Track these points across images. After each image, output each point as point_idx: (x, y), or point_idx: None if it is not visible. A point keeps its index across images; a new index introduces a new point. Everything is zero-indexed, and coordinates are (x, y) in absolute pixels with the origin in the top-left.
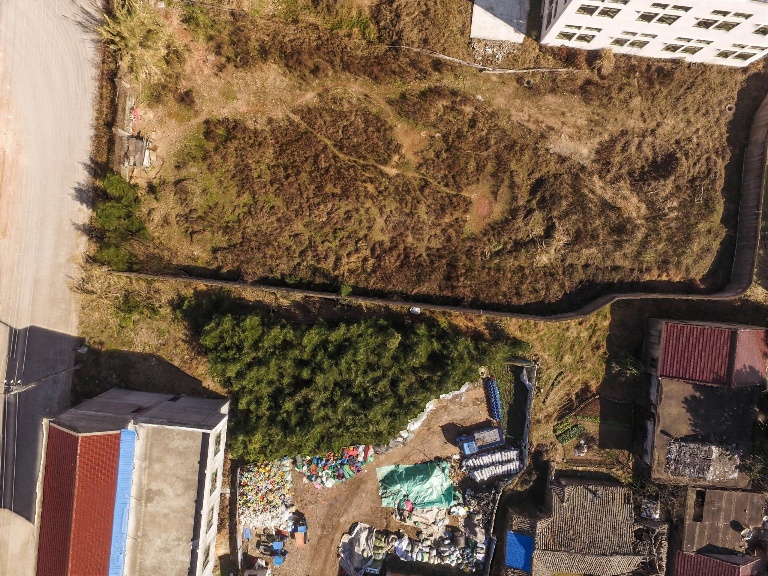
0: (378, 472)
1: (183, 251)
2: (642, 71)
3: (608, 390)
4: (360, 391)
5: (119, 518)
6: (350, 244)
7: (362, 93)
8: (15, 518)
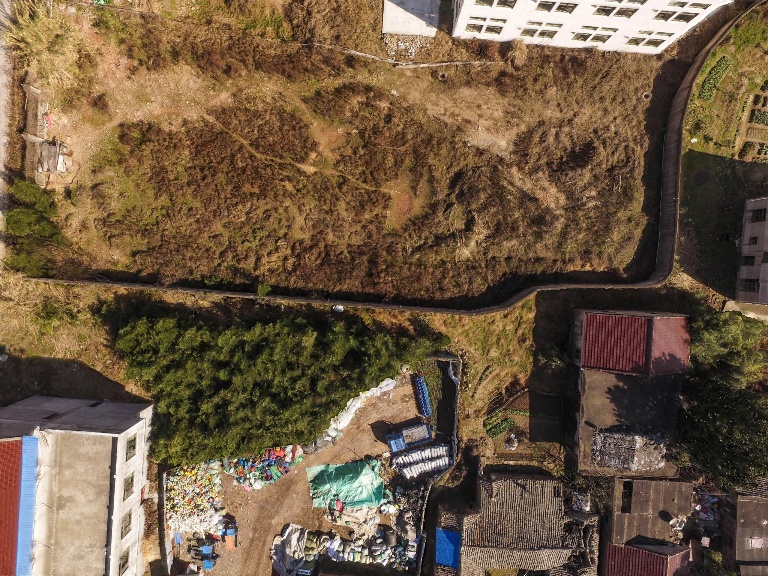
0: (308, 472)
1: (102, 255)
2: (556, 61)
3: (537, 383)
4: (280, 391)
5: (29, 526)
6: (270, 243)
7: (276, 92)
8: None
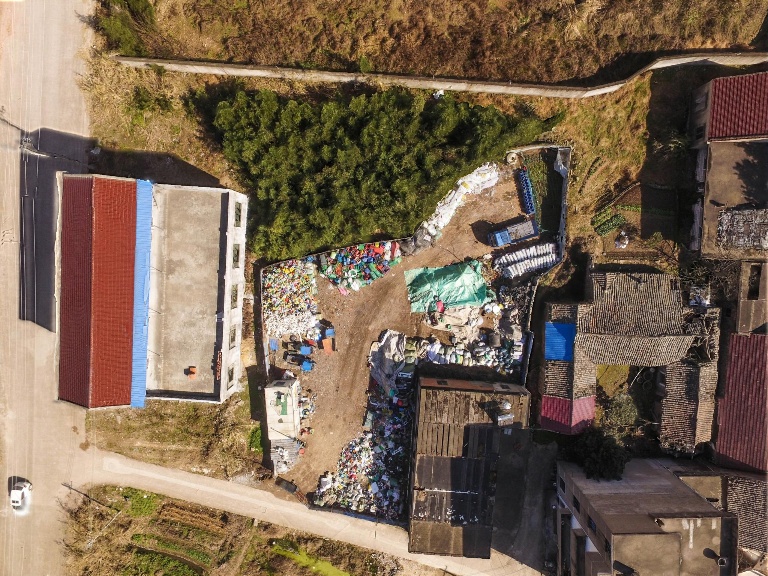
0: (406, 276)
1: (192, 43)
2: None
3: (650, 175)
4: (384, 170)
5: (140, 285)
6: (367, 25)
7: None
8: (39, 330)
